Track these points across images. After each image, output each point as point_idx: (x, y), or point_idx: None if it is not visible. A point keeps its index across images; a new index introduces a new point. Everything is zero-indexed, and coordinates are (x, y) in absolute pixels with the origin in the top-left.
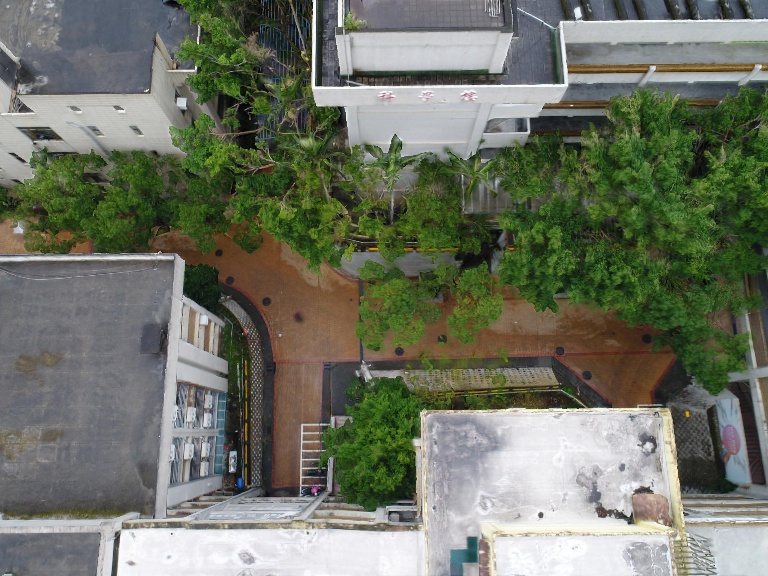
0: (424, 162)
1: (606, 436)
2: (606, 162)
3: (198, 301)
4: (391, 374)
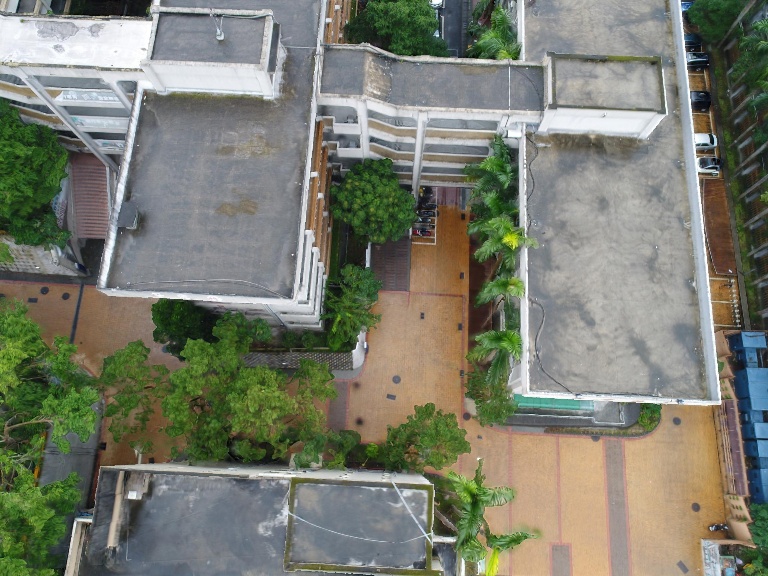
0: None
1: None
2: None
3: None
4: (52, 268)
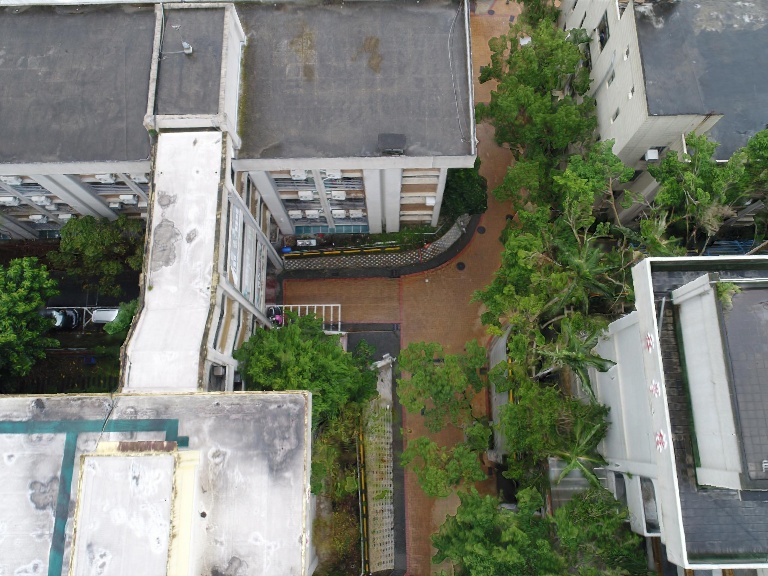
0: (603, 410)
1: None
2: None
3: (448, 194)
4: (387, 391)
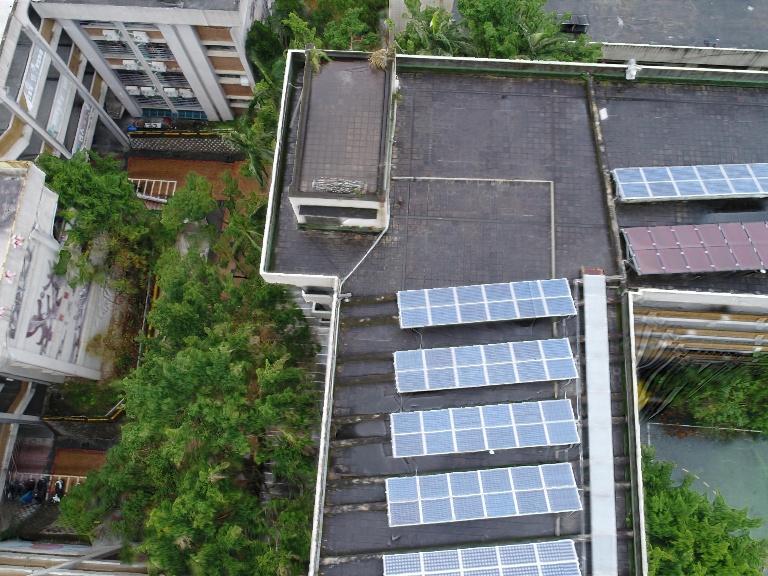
0: None
1: None
2: (238, 358)
3: (258, 74)
4: None
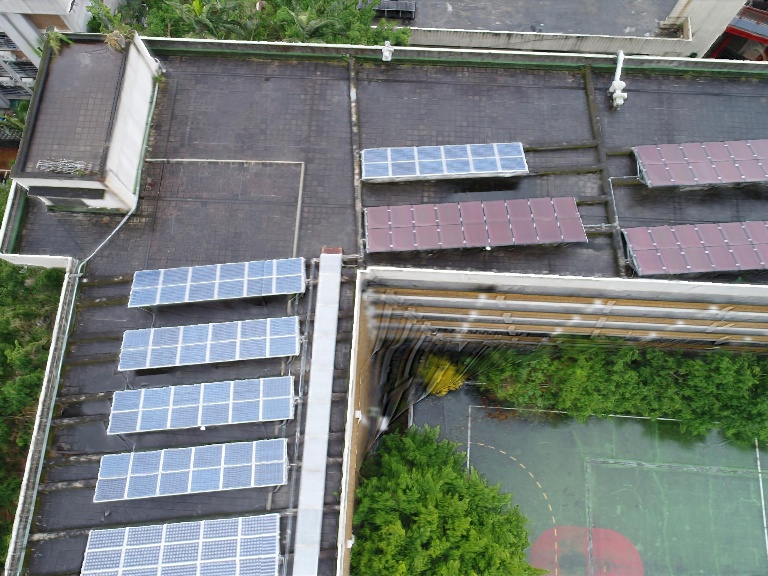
0: None
1: None
2: (4, 341)
3: None
4: None
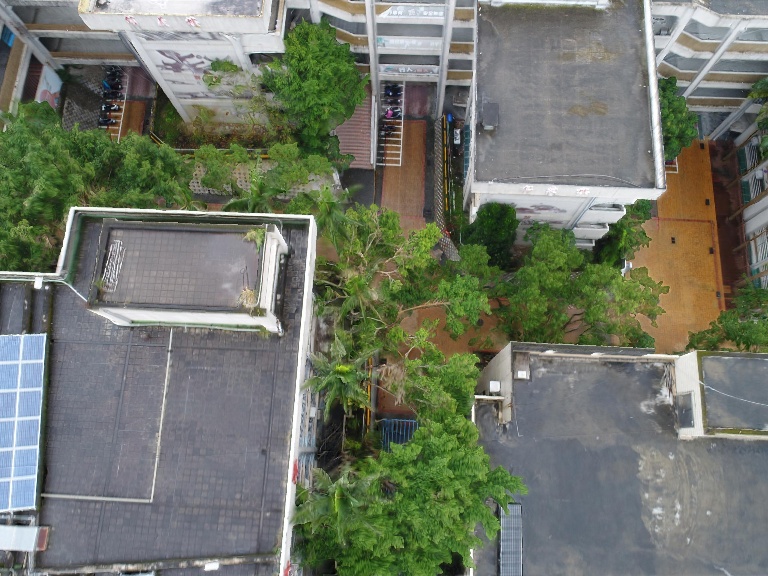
0: None
1: (131, 8)
2: None
3: None
4: None
